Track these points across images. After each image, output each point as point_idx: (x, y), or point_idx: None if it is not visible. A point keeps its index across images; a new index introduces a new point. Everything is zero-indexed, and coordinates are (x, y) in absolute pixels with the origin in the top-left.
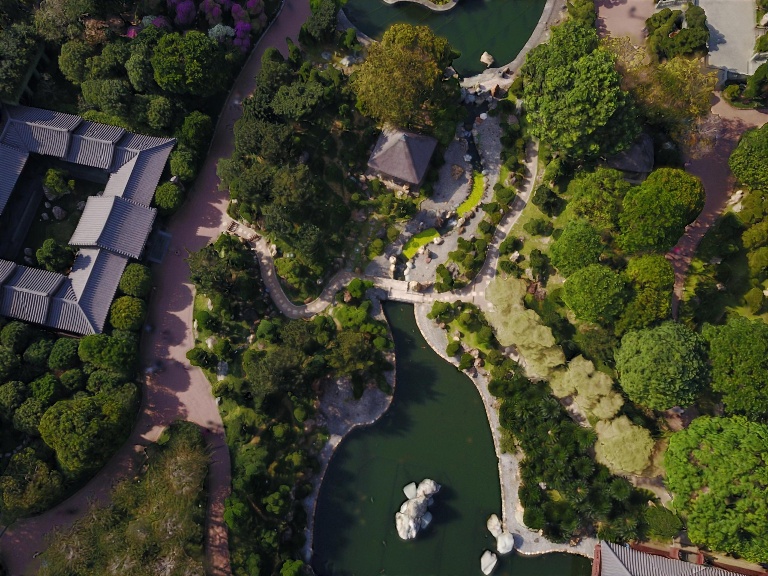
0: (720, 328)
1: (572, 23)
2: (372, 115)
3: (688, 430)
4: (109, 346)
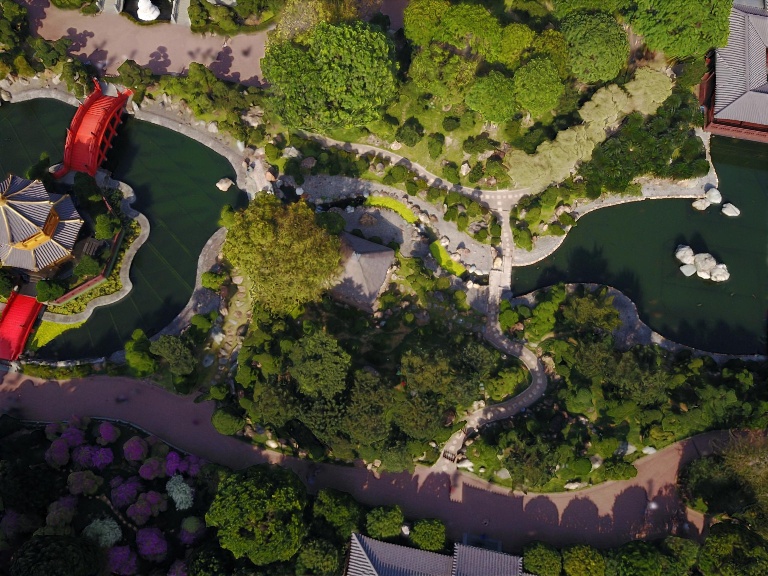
0: (562, 0)
1: (267, 61)
2: (326, 289)
3: (650, 33)
4: (639, 571)
